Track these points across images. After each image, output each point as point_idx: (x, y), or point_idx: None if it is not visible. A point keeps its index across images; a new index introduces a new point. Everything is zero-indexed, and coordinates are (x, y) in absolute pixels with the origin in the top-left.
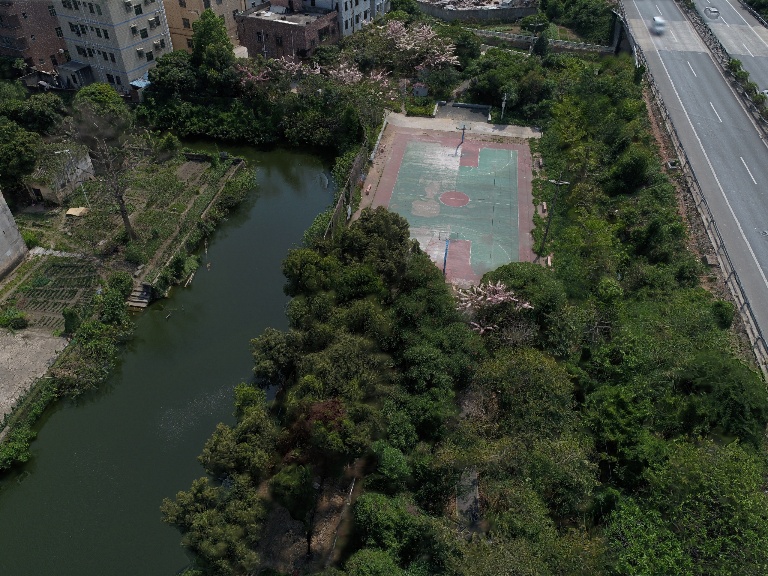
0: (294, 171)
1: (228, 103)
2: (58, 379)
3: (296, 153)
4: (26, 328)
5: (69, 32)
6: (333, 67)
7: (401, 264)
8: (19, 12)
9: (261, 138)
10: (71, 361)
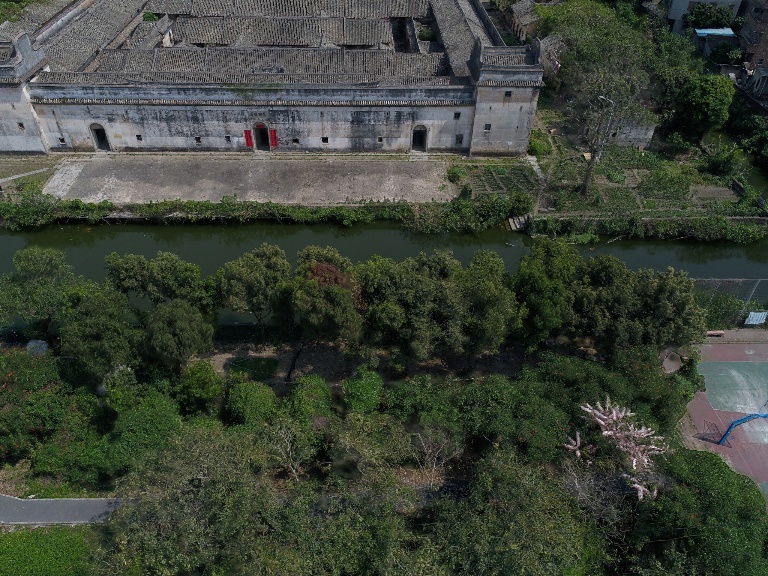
0: None
1: None
2: None
3: None
4: (453, 183)
5: None
6: None
7: (616, 331)
8: None
9: None
10: (429, 209)
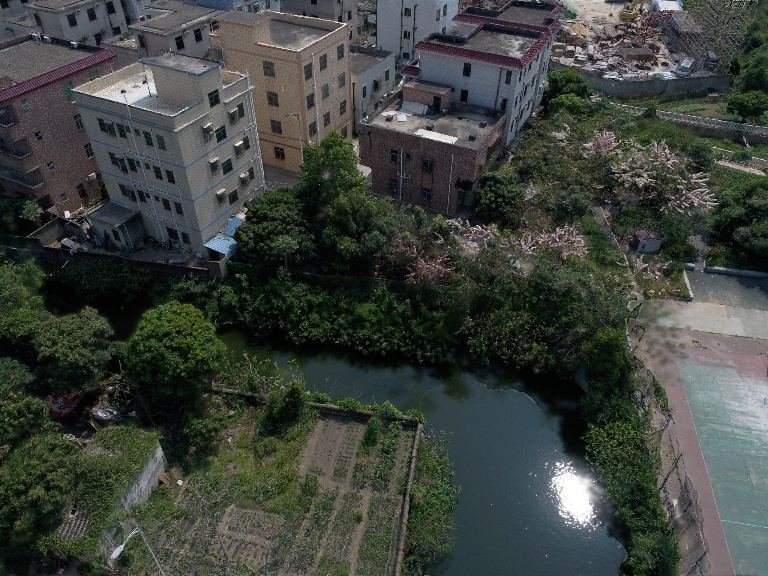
0: (461, 378)
1: (366, 285)
2: None
3: (490, 382)
4: None
5: (109, 165)
6: (515, 208)
7: None
8: (29, 132)
9: (428, 353)
10: None
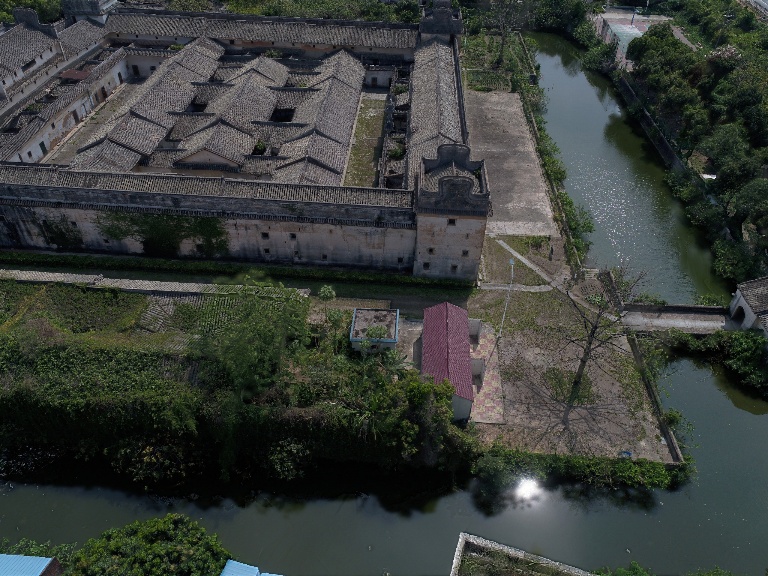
0: None
1: (488, 7)
2: (531, 102)
3: (537, 32)
4: (492, 91)
5: None
6: None
7: None
8: None
9: None
10: None
